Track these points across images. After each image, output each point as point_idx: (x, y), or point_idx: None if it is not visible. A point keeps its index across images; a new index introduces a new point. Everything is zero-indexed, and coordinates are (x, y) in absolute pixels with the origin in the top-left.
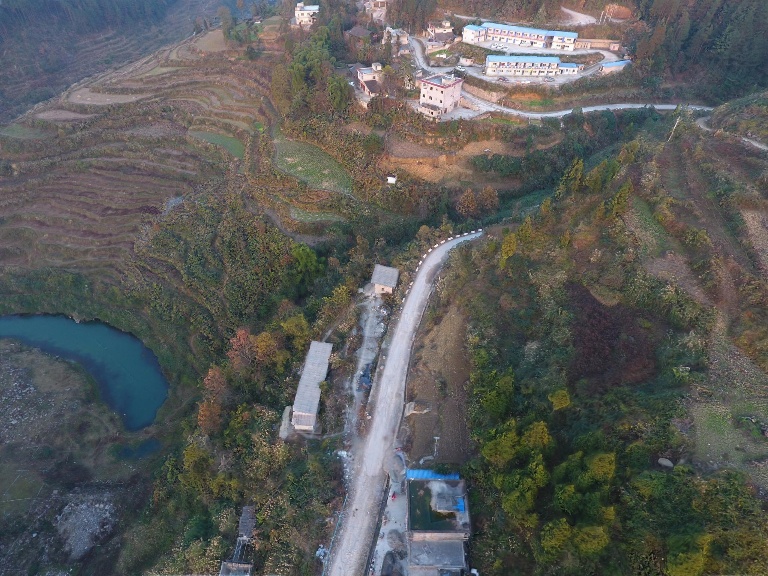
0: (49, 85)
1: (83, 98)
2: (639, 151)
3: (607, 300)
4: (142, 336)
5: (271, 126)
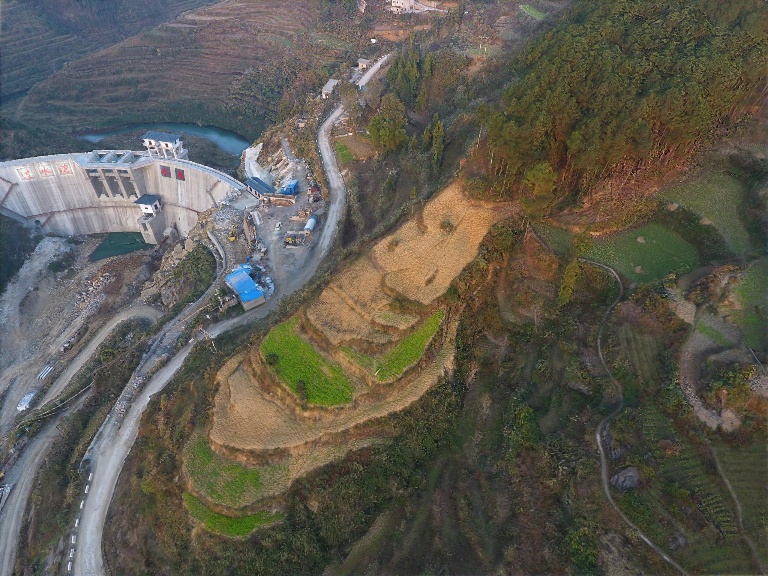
0: (152, 25)
1: (193, 17)
2: (481, 8)
3: None
4: (238, 128)
5: (309, 28)
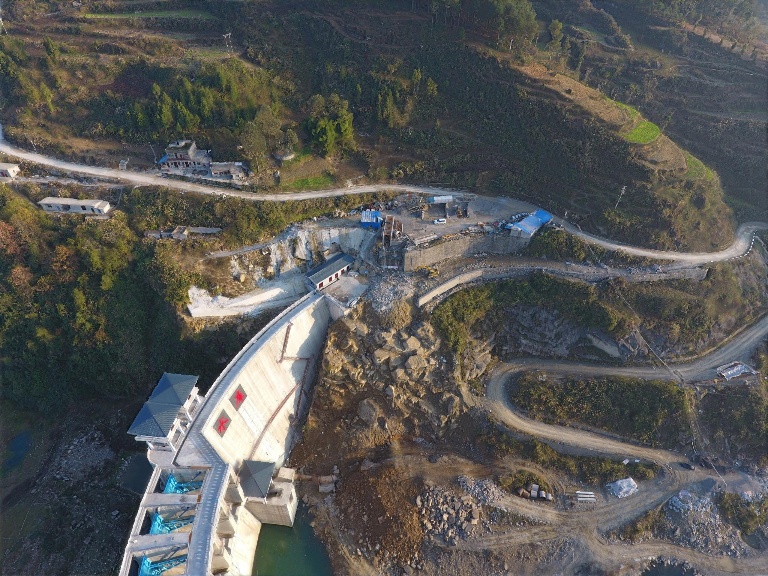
0: None
1: None
2: None
3: (110, 81)
4: None
5: None
